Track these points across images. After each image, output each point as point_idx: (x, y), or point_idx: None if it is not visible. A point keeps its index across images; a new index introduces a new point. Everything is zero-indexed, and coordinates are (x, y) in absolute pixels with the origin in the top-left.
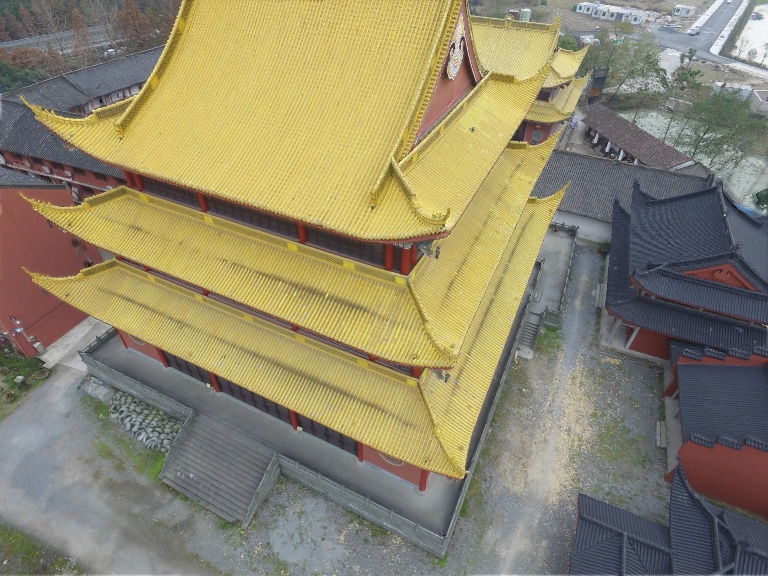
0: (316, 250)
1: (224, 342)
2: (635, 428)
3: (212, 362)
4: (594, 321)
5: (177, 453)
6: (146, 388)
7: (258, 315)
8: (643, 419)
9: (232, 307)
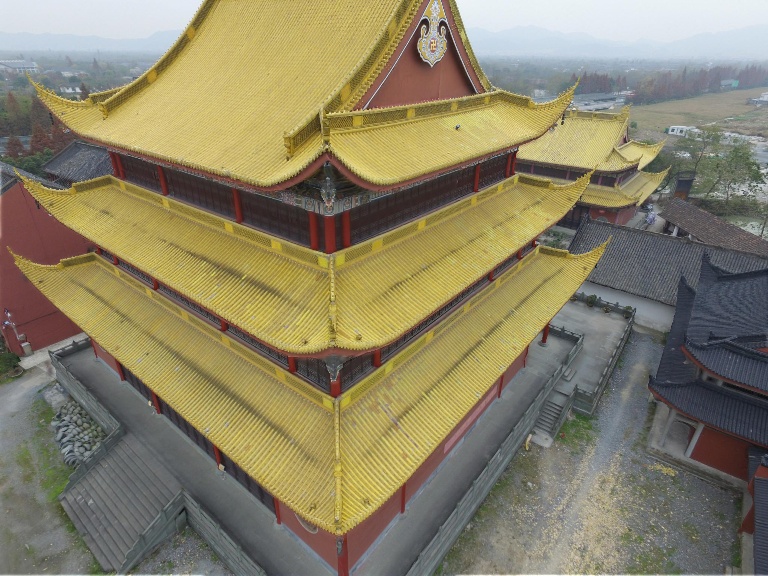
0: (247, 229)
1: (154, 339)
2: (689, 569)
3: (133, 358)
4: (645, 417)
5: (88, 473)
6: (89, 396)
7: (194, 312)
8: (704, 558)
9: (172, 302)
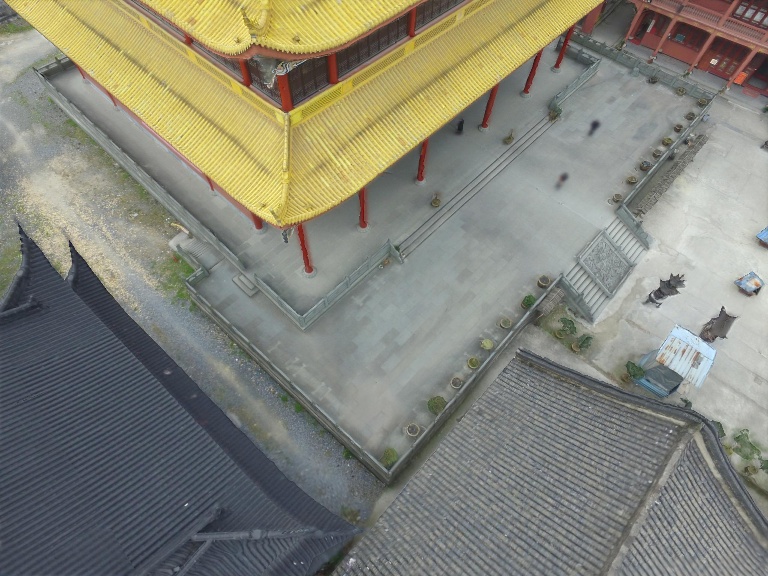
0: None
1: None
2: None
3: None
4: None
5: None
6: None
7: None
8: None
9: None
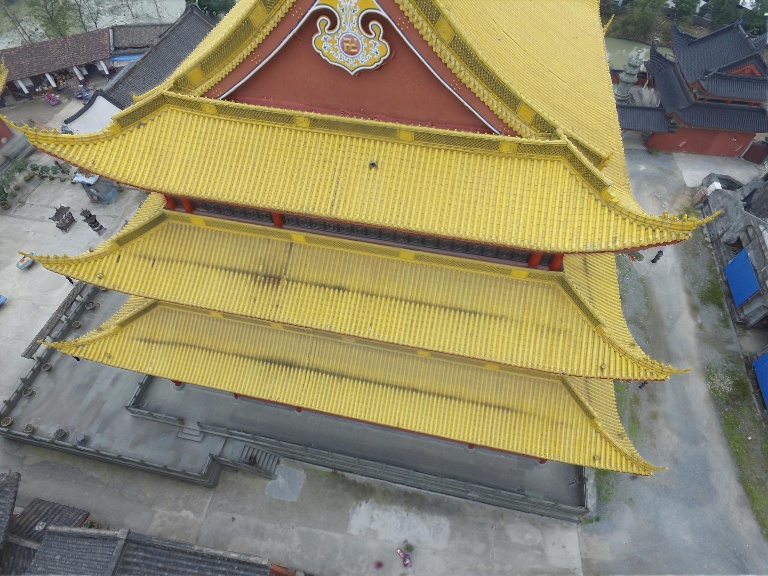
0: None
1: None
2: None
3: None
4: None
5: None
6: None
7: None
8: None
9: None
